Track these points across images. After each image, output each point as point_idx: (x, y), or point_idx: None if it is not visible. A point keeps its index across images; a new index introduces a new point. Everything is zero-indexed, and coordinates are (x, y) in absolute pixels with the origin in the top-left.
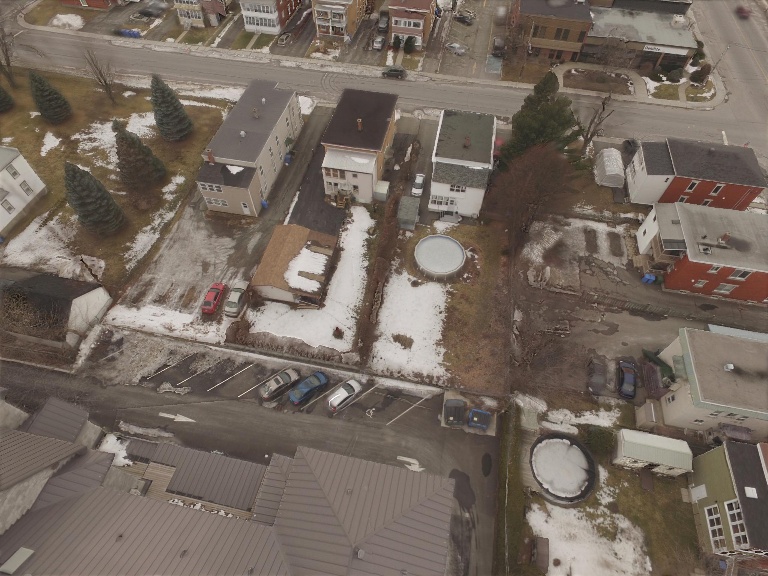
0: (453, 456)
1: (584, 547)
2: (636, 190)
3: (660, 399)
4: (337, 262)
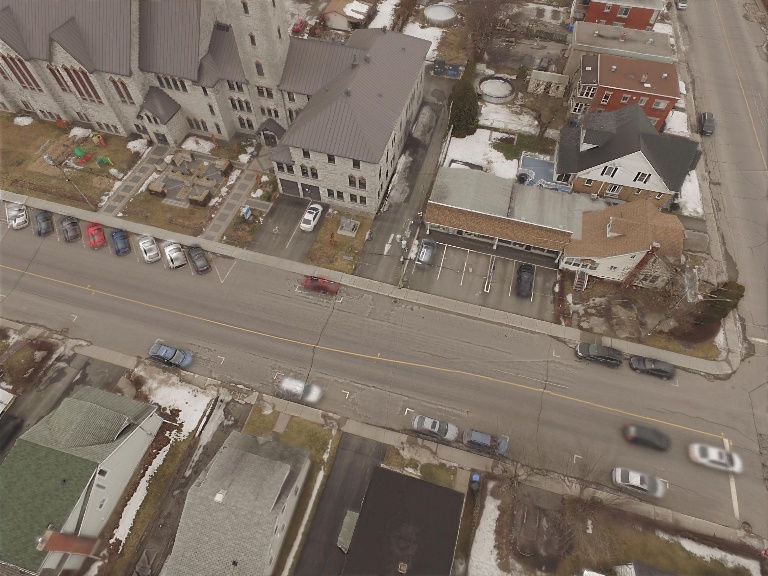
0: (436, 85)
1: (503, 115)
2: None
3: None
4: (375, 16)
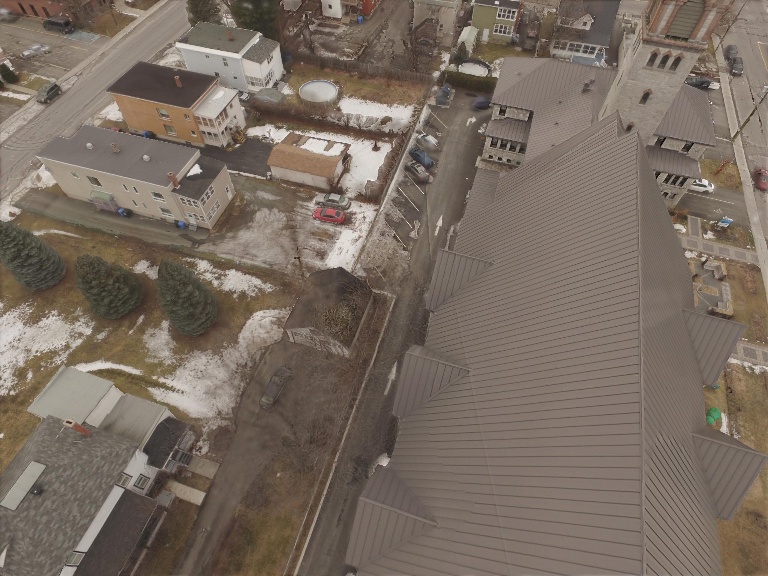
0: (467, 106)
1: None
2: (291, 2)
3: (437, 36)
4: None
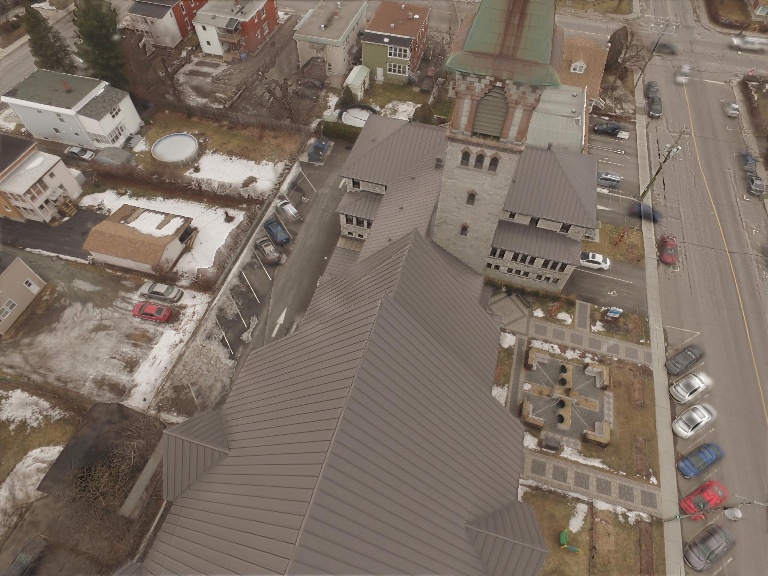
0: None
1: None
2: (166, 37)
3: (327, 76)
4: None
